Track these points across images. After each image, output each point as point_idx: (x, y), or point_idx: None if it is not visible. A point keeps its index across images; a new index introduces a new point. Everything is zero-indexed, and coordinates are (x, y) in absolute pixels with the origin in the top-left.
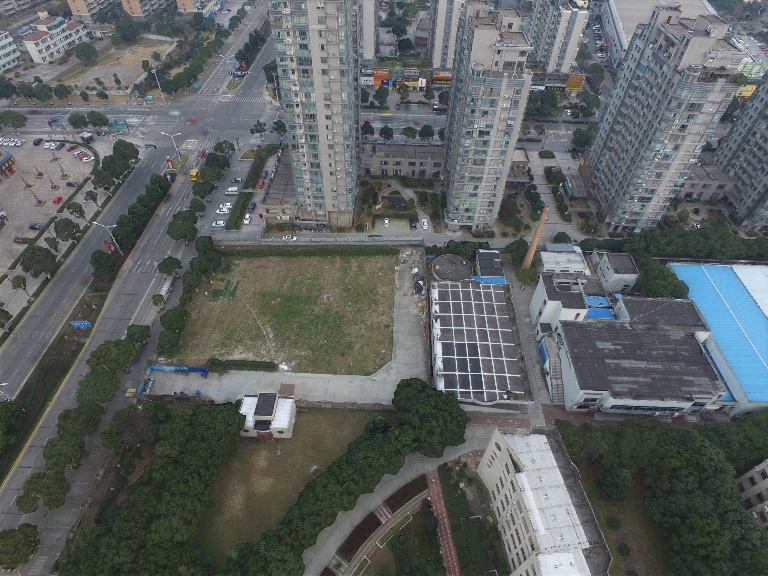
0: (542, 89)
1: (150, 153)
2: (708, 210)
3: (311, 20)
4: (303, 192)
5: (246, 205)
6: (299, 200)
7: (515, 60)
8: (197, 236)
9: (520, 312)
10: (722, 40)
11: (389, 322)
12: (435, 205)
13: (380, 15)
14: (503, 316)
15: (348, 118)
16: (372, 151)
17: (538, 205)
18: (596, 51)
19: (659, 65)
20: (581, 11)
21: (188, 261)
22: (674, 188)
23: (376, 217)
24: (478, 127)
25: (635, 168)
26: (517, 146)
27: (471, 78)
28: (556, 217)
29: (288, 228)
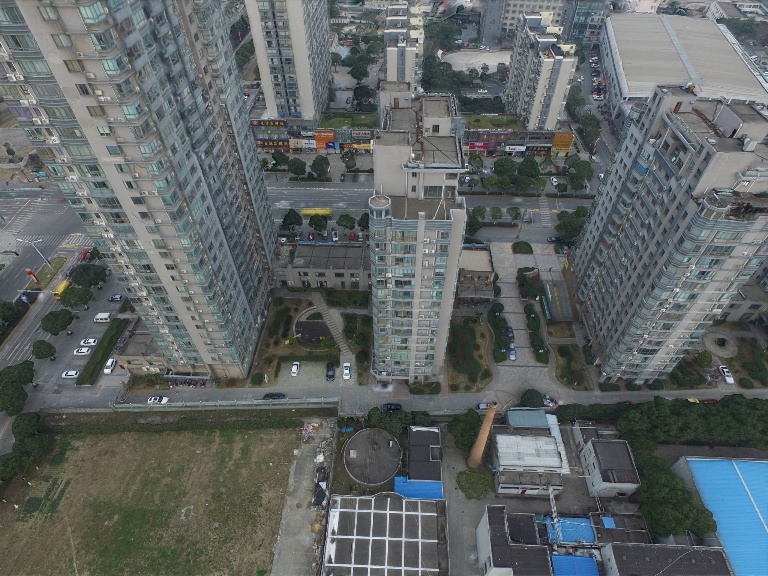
0: (522, 149)
1: (20, 255)
2: (738, 339)
3: (97, 151)
4: (166, 346)
5: (114, 342)
6: (164, 354)
7: (441, 184)
8: (37, 395)
9: (463, 540)
10: (761, 144)
11: (266, 564)
12: (360, 345)
13: (339, 54)
14: (430, 569)
15: (199, 267)
16: (289, 257)
17: (502, 340)
18: (592, 92)
19: (664, 172)
20: (566, 59)
21: (11, 442)
22: (690, 339)
23: (282, 360)
24: (393, 276)
25: (632, 314)
26: (480, 245)
27: (370, 218)
28: (528, 355)
29: (160, 381)
